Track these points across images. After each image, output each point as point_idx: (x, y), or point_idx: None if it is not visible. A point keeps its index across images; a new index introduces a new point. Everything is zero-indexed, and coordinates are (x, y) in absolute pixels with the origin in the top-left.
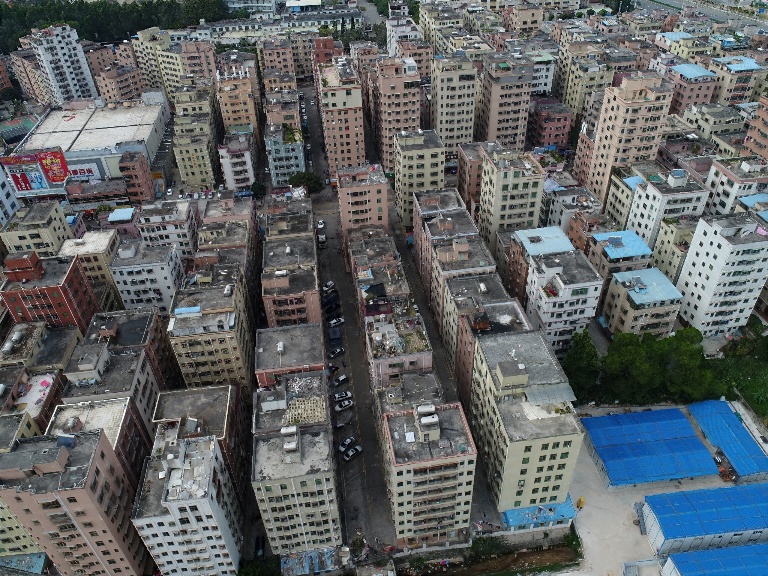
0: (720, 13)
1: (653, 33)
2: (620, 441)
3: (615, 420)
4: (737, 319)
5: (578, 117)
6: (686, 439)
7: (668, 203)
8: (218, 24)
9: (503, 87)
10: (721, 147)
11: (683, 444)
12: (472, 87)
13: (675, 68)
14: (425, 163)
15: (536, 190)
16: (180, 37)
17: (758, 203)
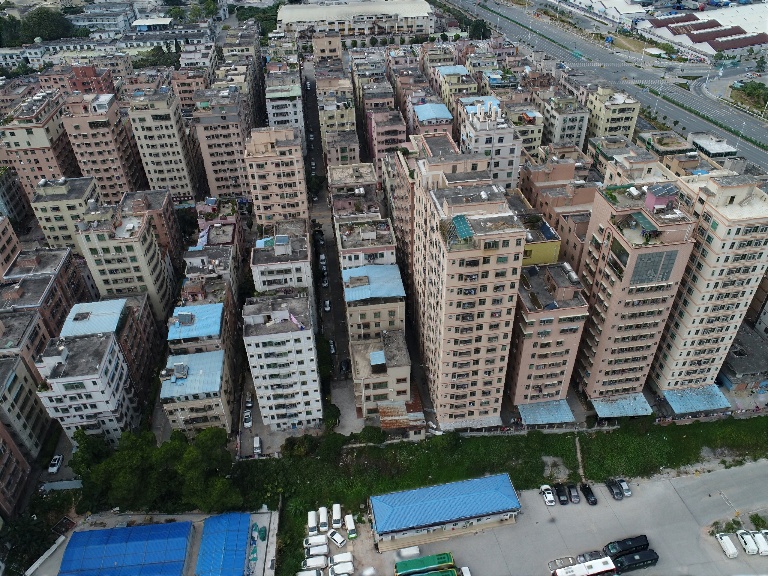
0: (578, 40)
1: (438, 66)
2: (93, 564)
3: (107, 536)
4: (308, 412)
5: (326, 157)
6: (168, 564)
7: (263, 274)
8: (53, 43)
9: (207, 128)
10: (392, 203)
11: (158, 571)
12: (171, 127)
13: (417, 108)
14: (64, 215)
15: (134, 254)
16: (12, 56)
17: (350, 278)
